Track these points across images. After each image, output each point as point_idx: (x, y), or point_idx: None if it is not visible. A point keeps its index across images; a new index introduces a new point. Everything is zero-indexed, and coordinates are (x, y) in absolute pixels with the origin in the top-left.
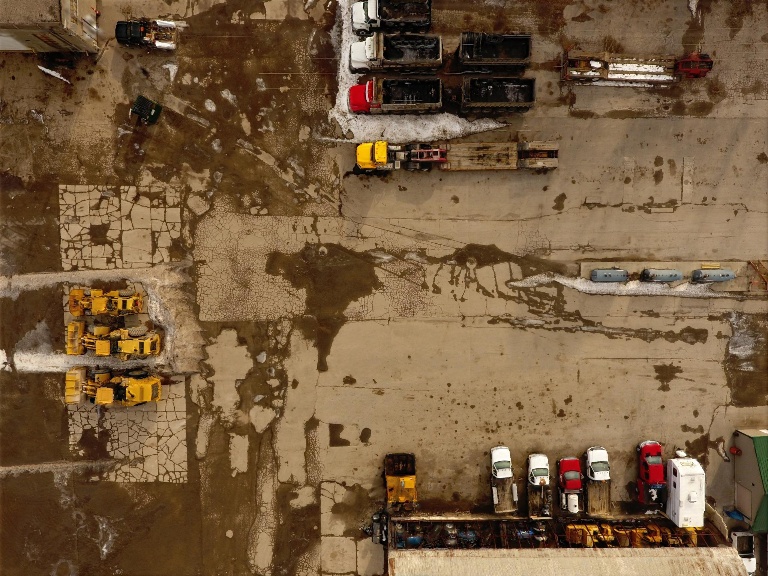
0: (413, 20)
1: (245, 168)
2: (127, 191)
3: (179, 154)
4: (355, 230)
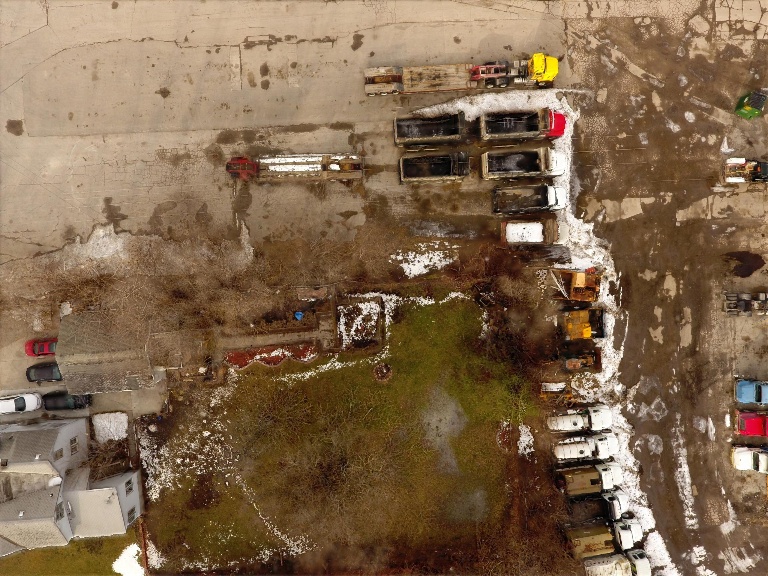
0: (509, 196)
1: (656, 61)
2: (765, 35)
3: (718, 71)
4: (551, 7)
